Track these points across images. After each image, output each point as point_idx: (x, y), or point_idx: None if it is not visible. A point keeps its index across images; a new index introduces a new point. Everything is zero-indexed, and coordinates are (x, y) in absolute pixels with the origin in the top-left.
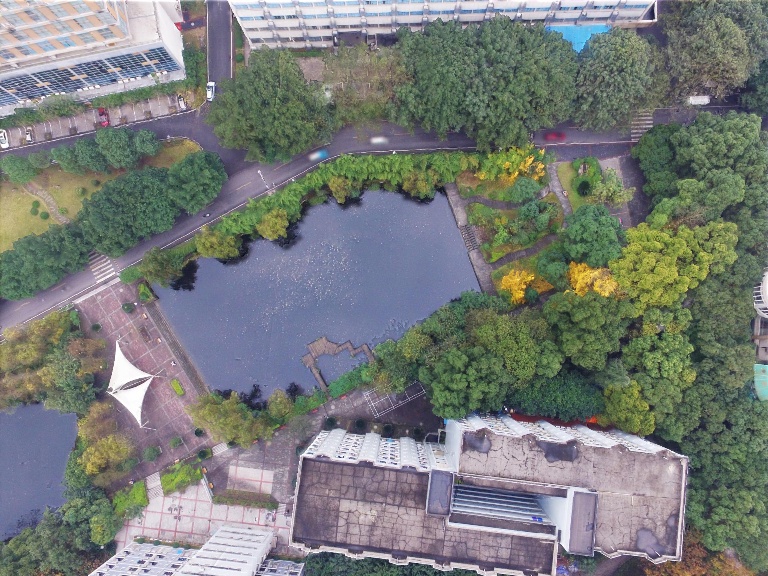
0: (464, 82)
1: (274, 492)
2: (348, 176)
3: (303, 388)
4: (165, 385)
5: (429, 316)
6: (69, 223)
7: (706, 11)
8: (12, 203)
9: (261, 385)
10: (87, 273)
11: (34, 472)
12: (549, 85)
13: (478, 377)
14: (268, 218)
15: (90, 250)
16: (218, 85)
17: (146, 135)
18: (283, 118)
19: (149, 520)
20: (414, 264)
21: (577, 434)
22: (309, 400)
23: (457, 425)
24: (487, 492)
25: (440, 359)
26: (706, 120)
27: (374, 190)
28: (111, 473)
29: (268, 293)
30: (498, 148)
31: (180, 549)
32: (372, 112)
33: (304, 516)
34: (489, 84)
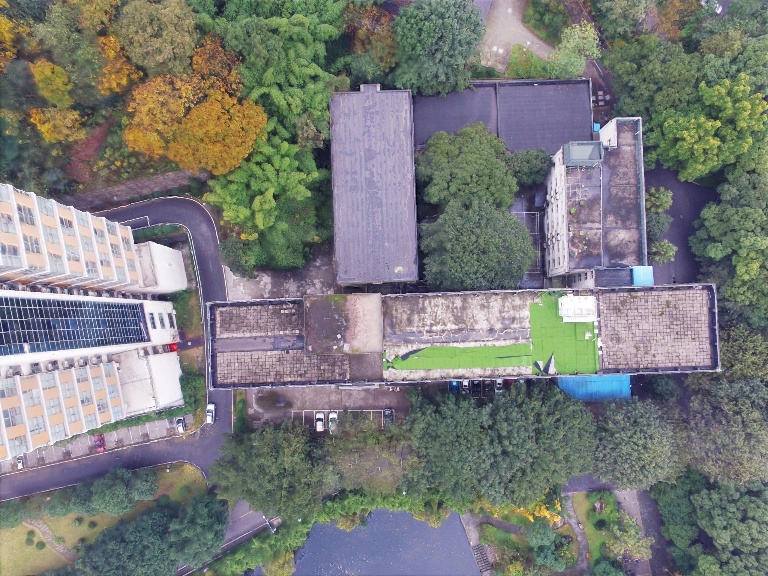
0: (479, 474)
1: None
2: (356, 512)
3: None
4: None
5: None
6: (67, 568)
7: (731, 391)
8: (6, 533)
9: None
10: None
11: None
12: (567, 465)
13: None
14: (275, 569)
15: None
16: (220, 451)
17: (145, 486)
18: (290, 510)
19: None
20: None
21: None
22: None
23: None
24: None
25: None
26: (729, 492)
27: None
28: None
29: None
30: None
31: None
32: None
33: None
34: None
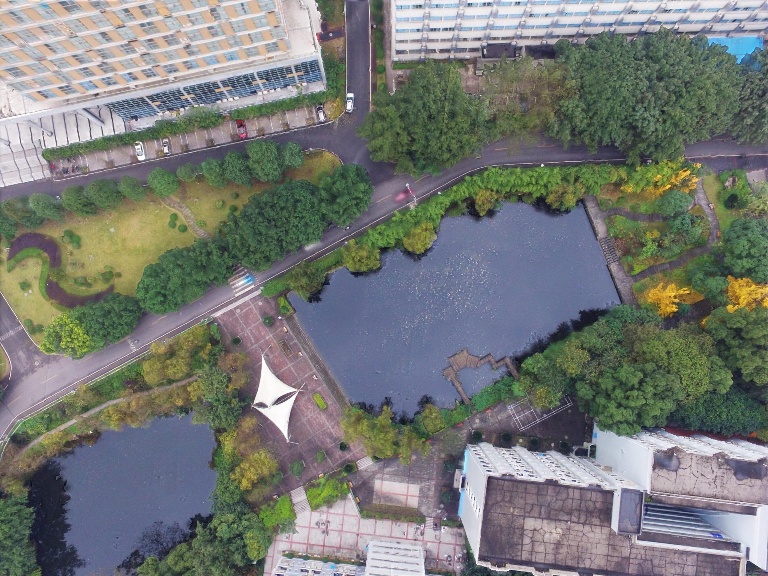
0: (635, 97)
1: (420, 506)
2: (494, 189)
3: (443, 401)
4: (307, 399)
5: (556, 327)
6: (213, 237)
7: None
8: (149, 216)
9: (393, 397)
10: (225, 286)
11: (171, 486)
12: (716, 99)
13: (652, 394)
14: (418, 232)
15: (233, 264)
16: (375, 98)
17: (295, 148)
18: (451, 133)
19: (296, 535)
20: (554, 277)
21: (748, 450)
22: (453, 414)
23: (635, 442)
24: (660, 508)
25: (600, 374)
26: None
27: (512, 202)
28: (263, 488)
29: (407, 306)
30: (646, 161)
31: (331, 564)
32: (534, 126)
33: (489, 534)
34: (660, 99)
